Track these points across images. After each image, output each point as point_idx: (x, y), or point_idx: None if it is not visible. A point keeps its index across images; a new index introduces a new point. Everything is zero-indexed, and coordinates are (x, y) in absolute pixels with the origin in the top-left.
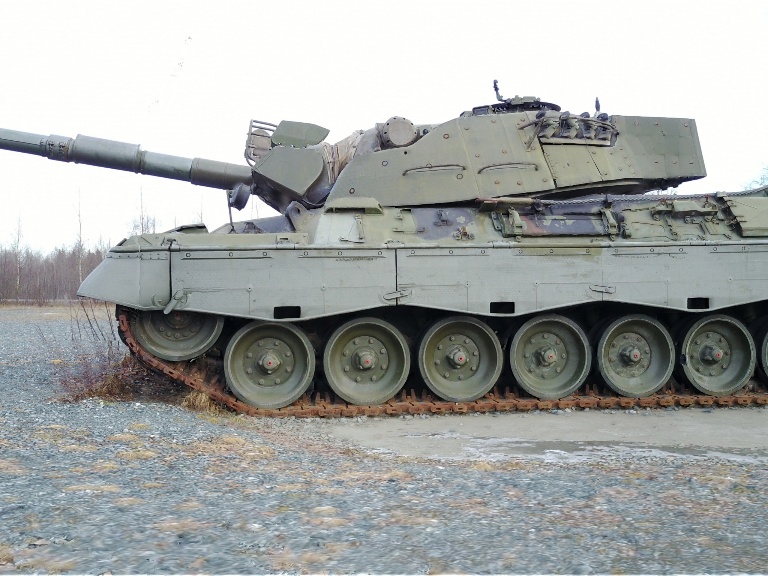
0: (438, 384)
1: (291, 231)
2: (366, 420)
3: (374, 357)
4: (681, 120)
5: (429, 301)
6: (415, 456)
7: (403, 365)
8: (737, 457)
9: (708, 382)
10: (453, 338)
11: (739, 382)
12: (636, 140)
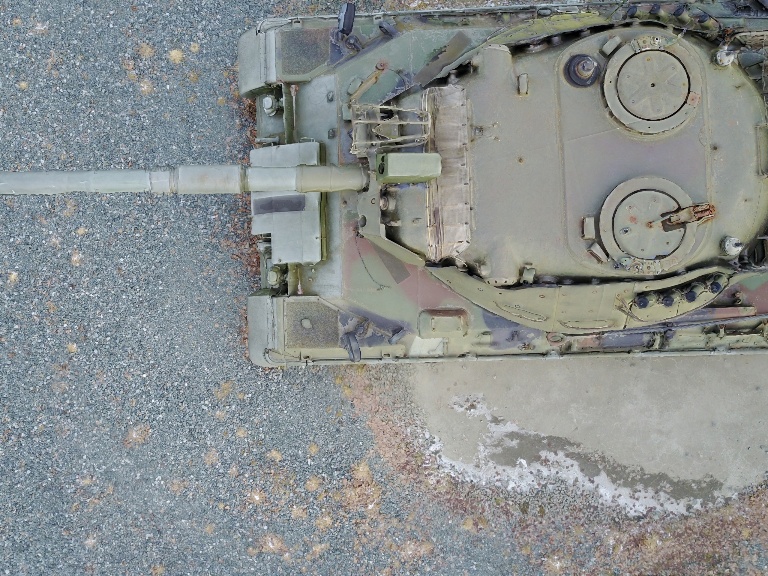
0: None
1: None
2: None
3: None
4: None
5: None
6: (447, 478)
7: None
8: (608, 488)
9: None
10: None
11: None
12: None
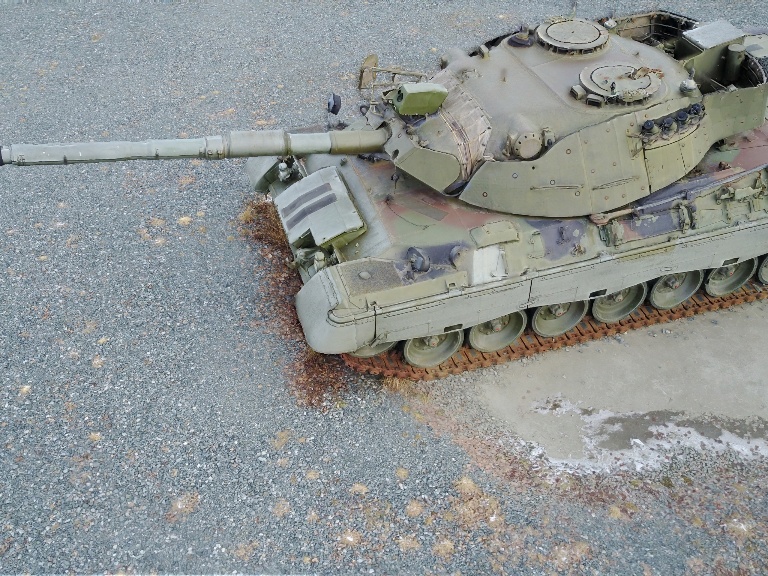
0: (542, 328)
1: (451, 265)
2: (499, 369)
3: None
4: (759, 88)
5: (550, 302)
6: (565, 475)
7: (522, 326)
8: (739, 443)
9: (718, 284)
10: None
11: (739, 286)
12: (717, 111)
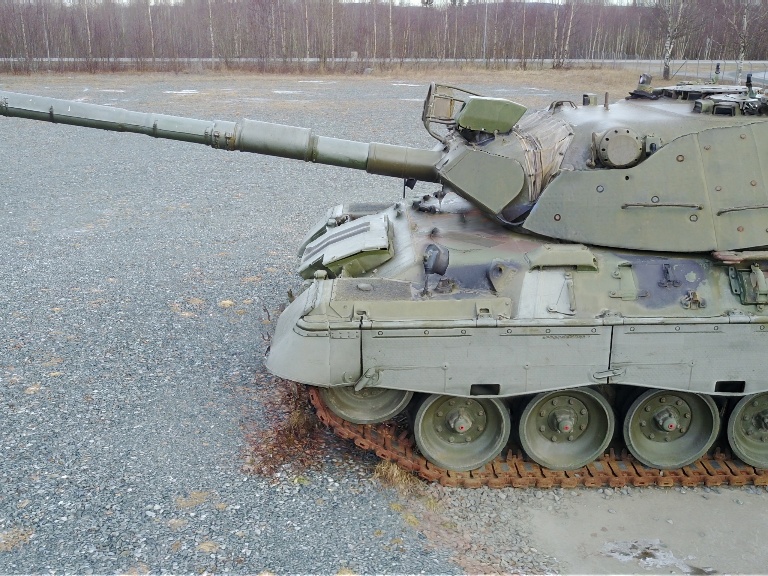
0: (642, 448)
1: (490, 290)
2: (563, 495)
3: (573, 417)
4: None
5: (645, 380)
6: None
7: (606, 432)
8: None
9: None
10: (664, 400)
11: None
12: None
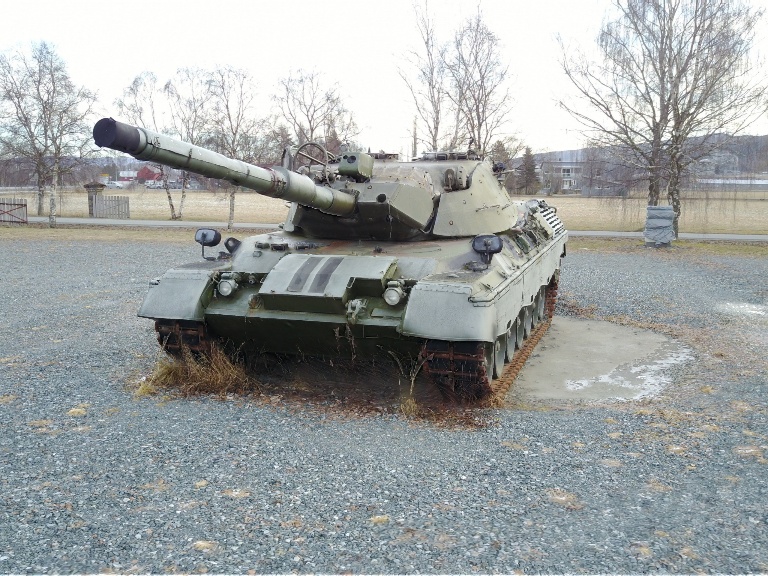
0: None
1: None
2: None
3: None
4: None
5: None
6: None
7: None
8: (668, 361)
9: None
10: None
11: None
12: None
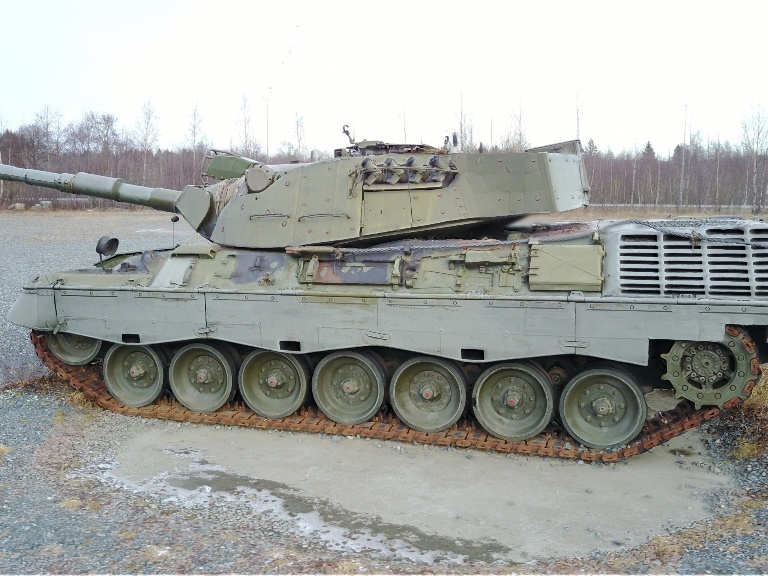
0: (256, 401)
1: (148, 271)
2: (186, 426)
3: (212, 373)
4: (528, 155)
5: (231, 337)
6: (92, 478)
7: (227, 383)
8: (313, 522)
9: (508, 425)
10: (273, 363)
11: (532, 430)
12: (478, 178)
